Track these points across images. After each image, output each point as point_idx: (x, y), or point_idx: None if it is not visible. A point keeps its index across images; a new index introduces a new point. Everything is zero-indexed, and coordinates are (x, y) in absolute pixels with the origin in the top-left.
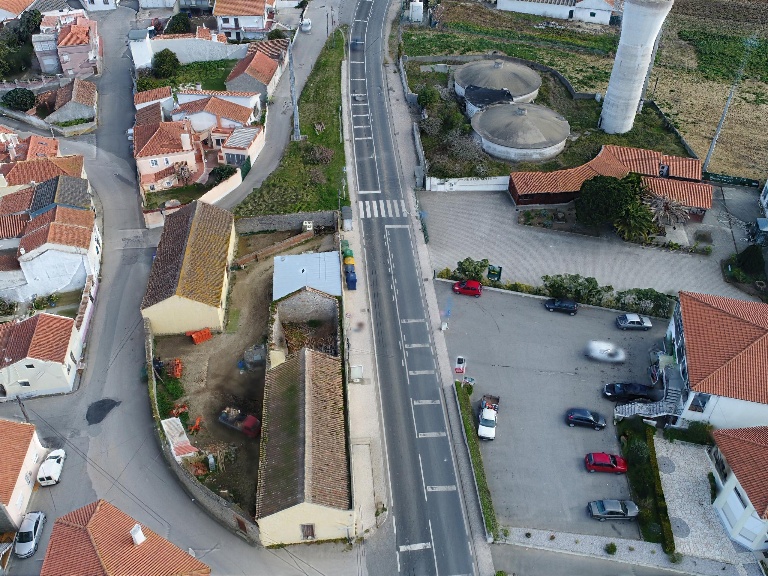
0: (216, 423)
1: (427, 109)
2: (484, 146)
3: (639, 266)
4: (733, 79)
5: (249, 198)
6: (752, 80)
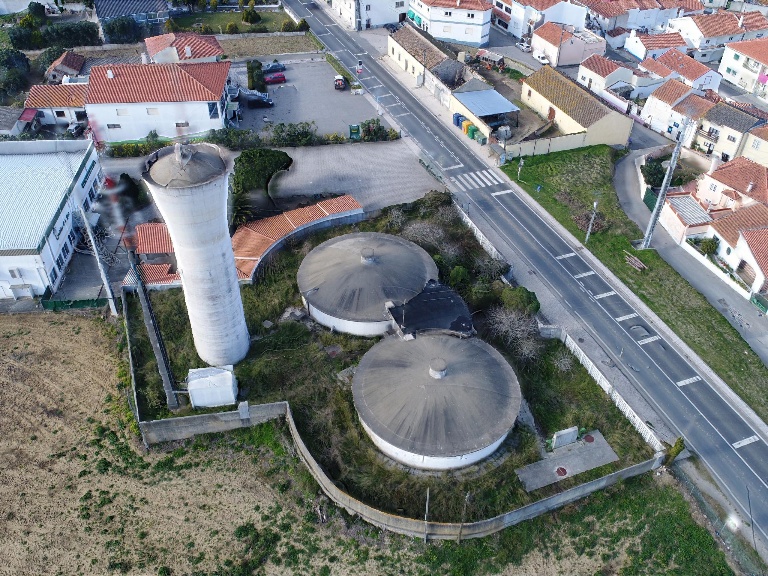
0: (482, 72)
1: None
2: None
3: None
4: None
5: (608, 172)
6: None
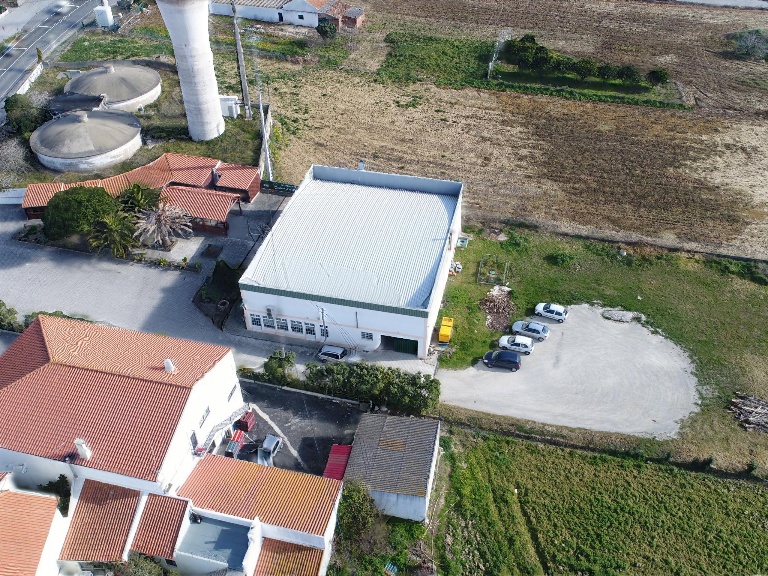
0: None
1: (6, 117)
2: (38, 156)
3: (108, 285)
4: (403, 82)
5: None
6: (424, 83)
